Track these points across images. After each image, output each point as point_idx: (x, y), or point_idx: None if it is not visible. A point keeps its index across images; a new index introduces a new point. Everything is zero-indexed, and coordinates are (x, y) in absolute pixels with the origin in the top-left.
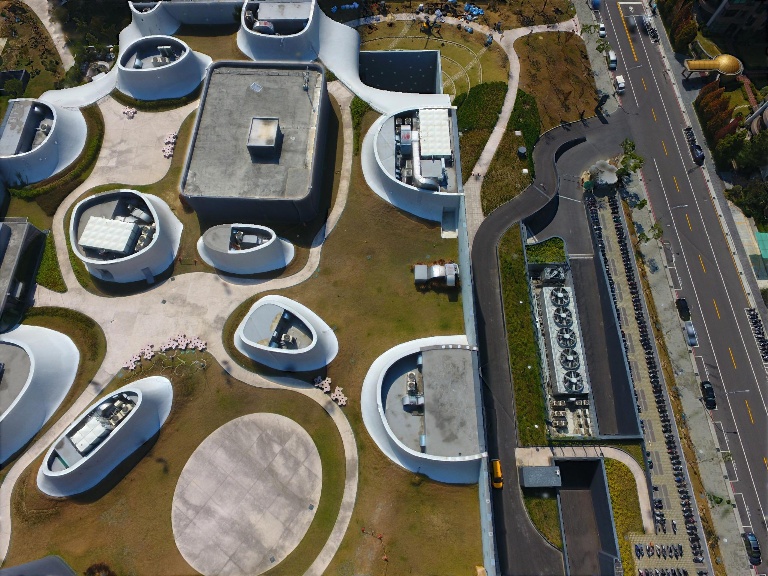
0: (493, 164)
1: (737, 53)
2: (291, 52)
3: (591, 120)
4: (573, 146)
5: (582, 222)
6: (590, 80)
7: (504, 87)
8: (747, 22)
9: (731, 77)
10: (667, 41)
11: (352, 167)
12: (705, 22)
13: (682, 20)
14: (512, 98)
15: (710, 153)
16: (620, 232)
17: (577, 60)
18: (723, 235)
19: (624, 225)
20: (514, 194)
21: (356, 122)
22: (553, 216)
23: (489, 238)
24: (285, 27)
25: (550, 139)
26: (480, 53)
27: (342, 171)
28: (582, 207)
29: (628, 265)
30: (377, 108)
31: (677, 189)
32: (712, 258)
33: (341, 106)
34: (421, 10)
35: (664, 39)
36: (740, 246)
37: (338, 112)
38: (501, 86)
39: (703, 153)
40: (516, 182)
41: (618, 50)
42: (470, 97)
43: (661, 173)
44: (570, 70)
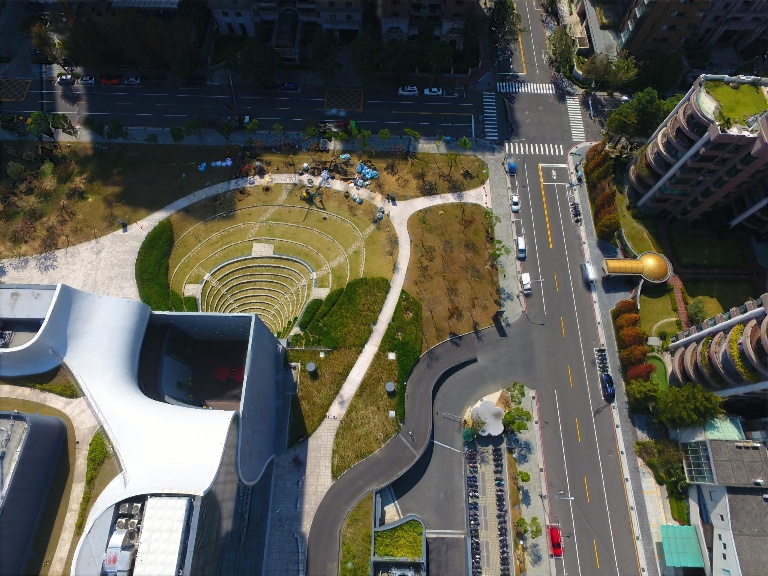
0: (354, 402)
1: (670, 243)
2: (22, 360)
3: (487, 331)
4: (460, 369)
5: (457, 482)
6: (493, 274)
7: (385, 286)
8: (681, 211)
9: (657, 283)
10: (590, 221)
11: (68, 555)
12: (637, 199)
13: (604, 206)
14: (393, 301)
15: (624, 386)
16: (500, 502)
17: (480, 245)
18: (627, 510)
19: (506, 493)
20: (374, 448)
21: (88, 478)
22: (423, 472)
23: (334, 514)
24: (21, 321)
25: (433, 360)
26: (366, 232)
27: (53, 561)
28: (460, 460)
29: (505, 552)
30: (121, 454)
31: (578, 438)
32: (610, 545)
33: (78, 443)
34: (305, 170)
35: (587, 218)
36: (646, 528)
37: (72, 453)
38: (383, 283)
39: (613, 390)
40: (378, 430)
41: (531, 231)
42: (344, 297)
43: (561, 413)
44: (470, 260)
